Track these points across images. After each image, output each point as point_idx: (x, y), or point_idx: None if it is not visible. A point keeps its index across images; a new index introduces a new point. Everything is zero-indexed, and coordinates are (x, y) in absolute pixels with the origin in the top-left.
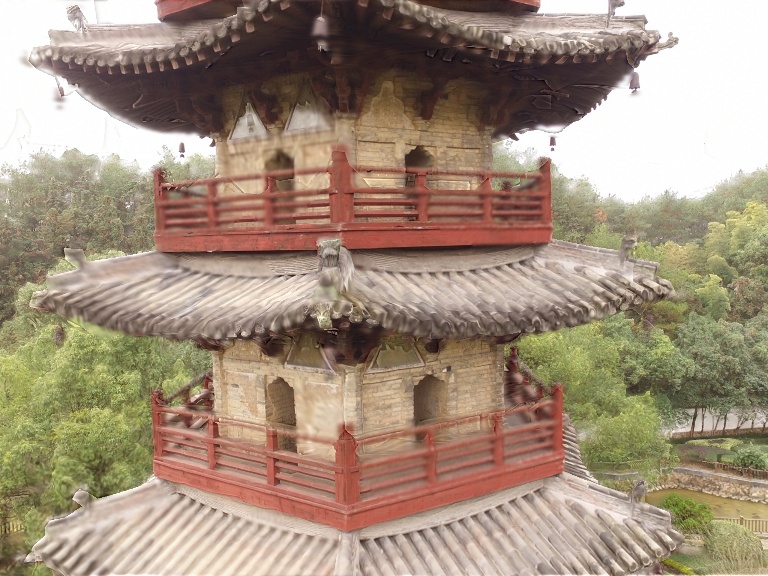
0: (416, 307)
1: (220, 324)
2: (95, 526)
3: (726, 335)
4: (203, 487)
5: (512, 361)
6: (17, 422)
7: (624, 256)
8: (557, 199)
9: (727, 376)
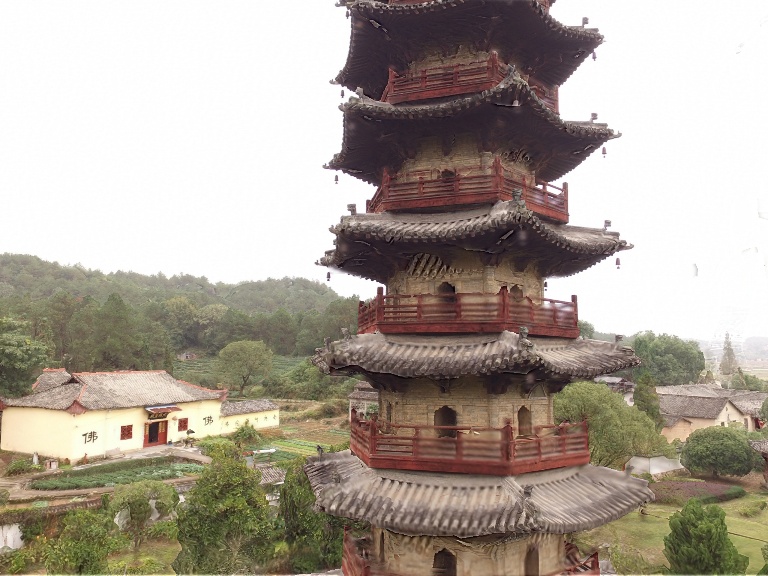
0: None
1: None
2: None
3: None
4: None
5: (374, 426)
6: None
7: None
8: None
9: None
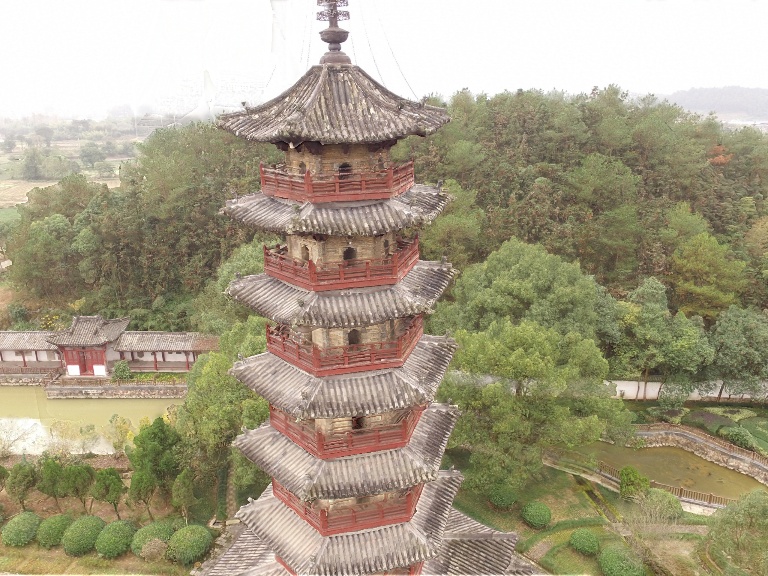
0: (338, 486)
1: (283, 481)
2: (255, 509)
3: (755, 330)
4: (287, 505)
5: None
6: (224, 394)
7: (425, 462)
8: (660, 159)
9: (746, 365)
